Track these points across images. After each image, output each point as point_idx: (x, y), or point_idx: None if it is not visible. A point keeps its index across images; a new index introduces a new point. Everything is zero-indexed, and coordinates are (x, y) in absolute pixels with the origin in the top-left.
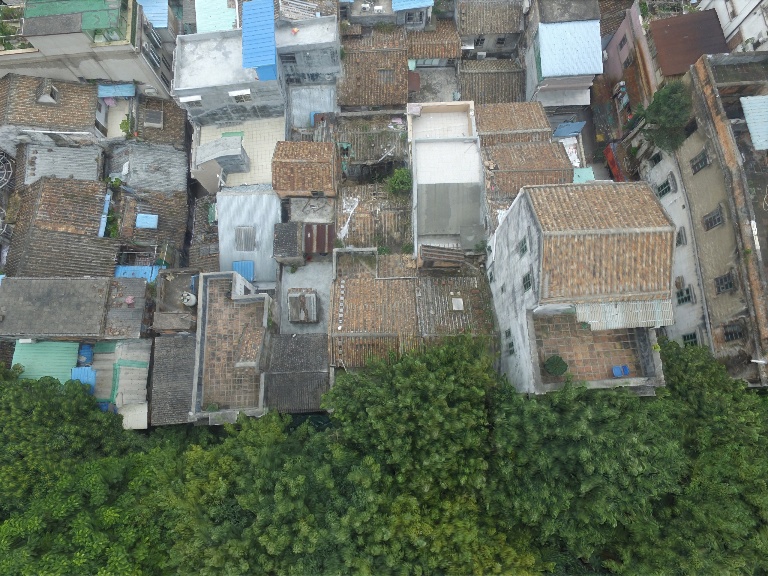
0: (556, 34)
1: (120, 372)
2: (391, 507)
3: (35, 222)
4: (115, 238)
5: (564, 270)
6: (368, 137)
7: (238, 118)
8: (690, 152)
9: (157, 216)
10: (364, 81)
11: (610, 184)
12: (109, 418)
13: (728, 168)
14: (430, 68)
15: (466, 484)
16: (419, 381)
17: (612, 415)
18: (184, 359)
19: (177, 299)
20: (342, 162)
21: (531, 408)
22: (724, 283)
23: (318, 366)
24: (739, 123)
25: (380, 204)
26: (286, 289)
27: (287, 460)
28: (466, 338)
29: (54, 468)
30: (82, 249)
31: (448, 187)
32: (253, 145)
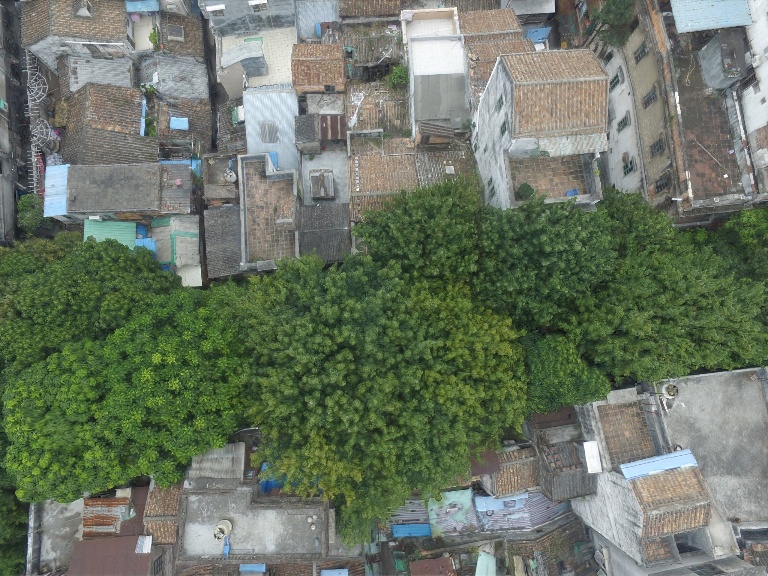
0: None
1: (176, 241)
2: (410, 292)
3: (87, 122)
4: (154, 137)
5: (530, 112)
6: (369, 41)
7: (254, 28)
8: (634, 46)
9: (187, 119)
10: None
11: (564, 51)
12: (172, 275)
13: (660, 53)
14: None
15: (462, 275)
16: (426, 202)
17: (564, 213)
18: (230, 226)
19: (219, 179)
20: (347, 64)
21: (508, 211)
22: (656, 147)
23: (340, 225)
24: (669, 16)
25: (382, 97)
26: (306, 174)
27: (329, 274)
28: (459, 177)
29: (144, 297)
30: (128, 146)
31: (439, 78)
32: (269, 52)
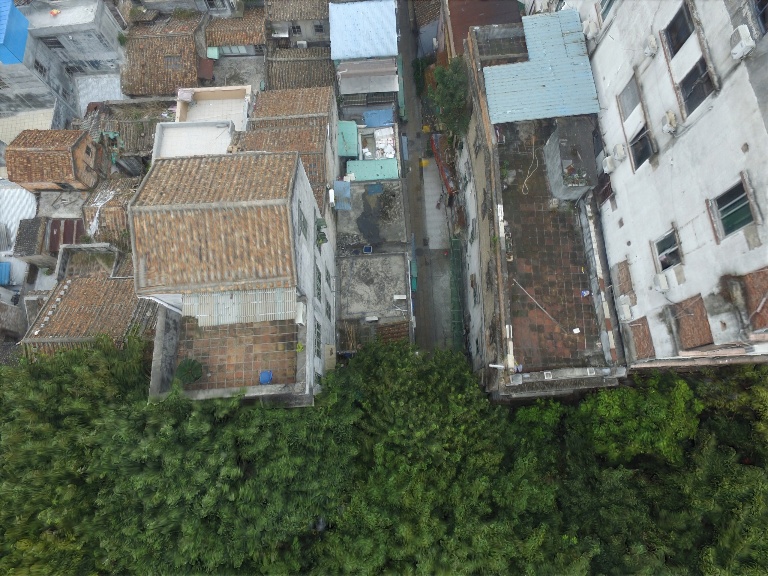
0: (348, 14)
1: None
2: None
3: None
4: None
5: (162, 253)
6: (136, 126)
7: (8, 109)
8: (472, 135)
9: None
10: (149, 68)
11: (254, 154)
12: None
13: (488, 148)
14: (240, 57)
15: None
16: None
17: (199, 430)
18: None
19: None
20: (111, 153)
21: (105, 422)
22: None
23: None
24: None
25: None
26: None
27: None
28: (103, 339)
29: None
30: None
31: None
32: None
